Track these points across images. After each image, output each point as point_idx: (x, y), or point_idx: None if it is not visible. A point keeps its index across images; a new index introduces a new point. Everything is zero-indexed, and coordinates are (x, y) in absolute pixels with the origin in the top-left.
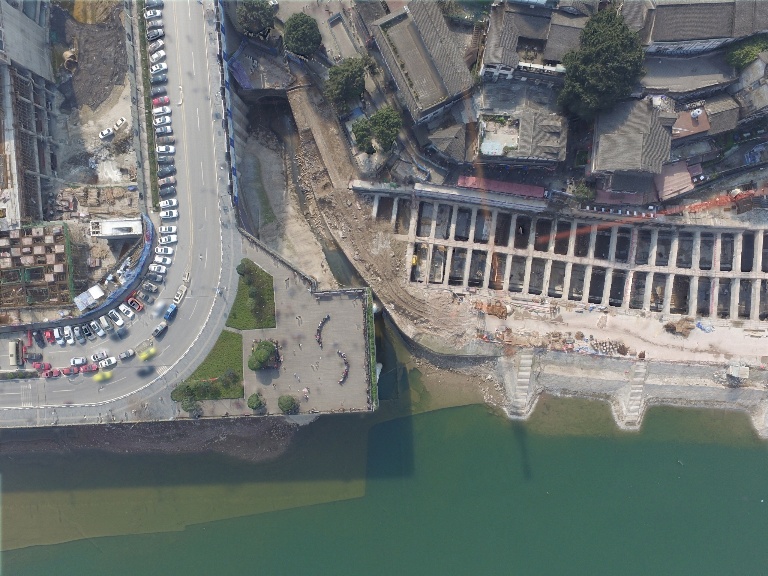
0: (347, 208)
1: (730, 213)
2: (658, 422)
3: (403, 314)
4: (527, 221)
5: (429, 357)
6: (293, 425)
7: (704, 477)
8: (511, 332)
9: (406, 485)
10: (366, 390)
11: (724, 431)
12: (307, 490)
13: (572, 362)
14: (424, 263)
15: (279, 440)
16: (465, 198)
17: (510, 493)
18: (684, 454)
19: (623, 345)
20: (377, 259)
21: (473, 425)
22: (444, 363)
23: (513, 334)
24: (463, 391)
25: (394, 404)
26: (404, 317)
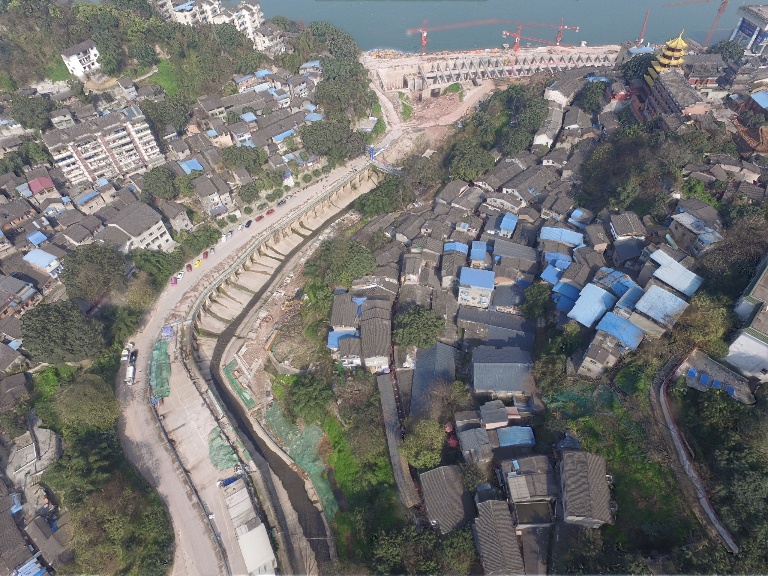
0: None
1: None
2: None
3: None
4: None
5: None
6: None
7: None
8: None
9: None
10: None
11: None
12: None
13: None
14: None
15: None
16: None
17: None
18: None
19: None
20: None
21: None
22: None
23: None
24: None
25: None
26: None
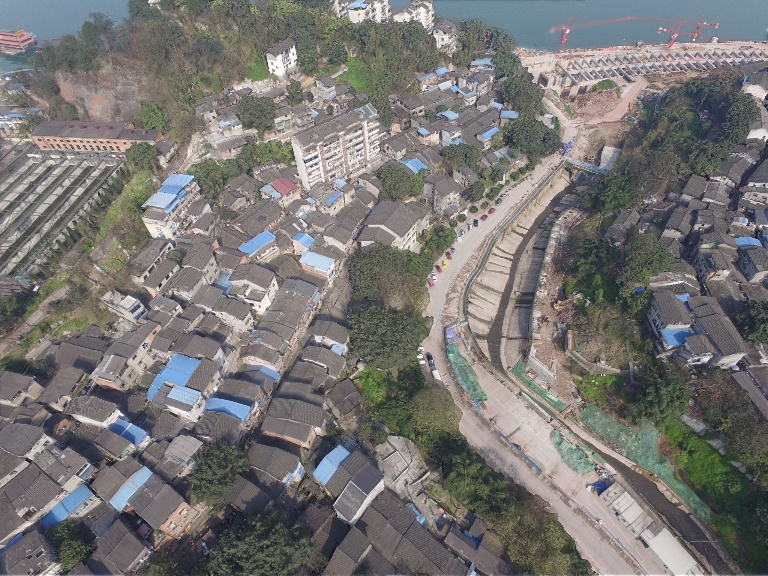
0: None
1: None
2: None
3: None
4: None
5: None
6: None
7: None
8: None
9: None
10: None
11: None
12: None
13: None
14: None
15: None
16: None
17: None
18: None
19: None
20: None
21: None
22: None
23: None
24: None
25: None
26: None
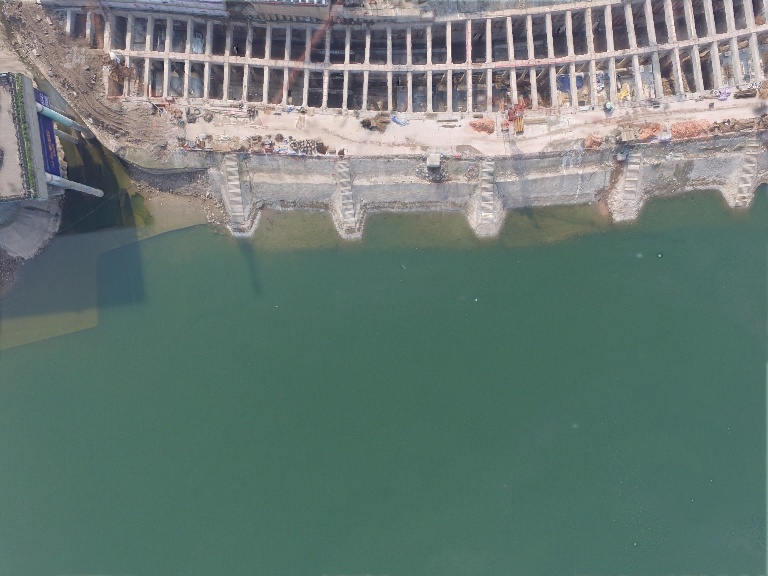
0: (37, 24)
1: (412, 3)
2: (380, 230)
3: (104, 129)
4: (240, 40)
5: (146, 178)
6: (18, 259)
7: (427, 279)
8: (212, 139)
9: (137, 311)
10: (20, 175)
11: (443, 233)
12: (39, 324)
13: (278, 167)
14: (131, 82)
15: (5, 275)
16: (147, 1)
17: (243, 312)
18: (407, 259)
19: (322, 144)
20: (70, 73)
21: (199, 246)
22: (162, 184)
23: (214, 141)
24: (186, 212)
25: (119, 231)
26: (105, 132)
